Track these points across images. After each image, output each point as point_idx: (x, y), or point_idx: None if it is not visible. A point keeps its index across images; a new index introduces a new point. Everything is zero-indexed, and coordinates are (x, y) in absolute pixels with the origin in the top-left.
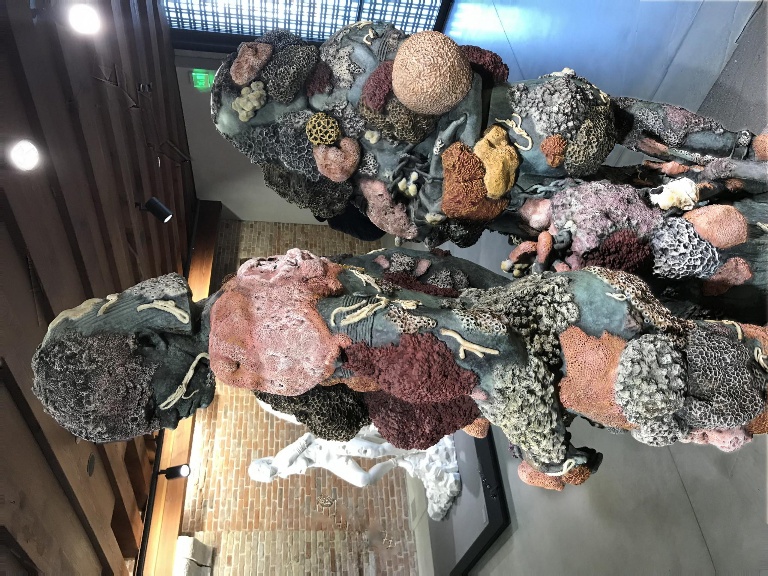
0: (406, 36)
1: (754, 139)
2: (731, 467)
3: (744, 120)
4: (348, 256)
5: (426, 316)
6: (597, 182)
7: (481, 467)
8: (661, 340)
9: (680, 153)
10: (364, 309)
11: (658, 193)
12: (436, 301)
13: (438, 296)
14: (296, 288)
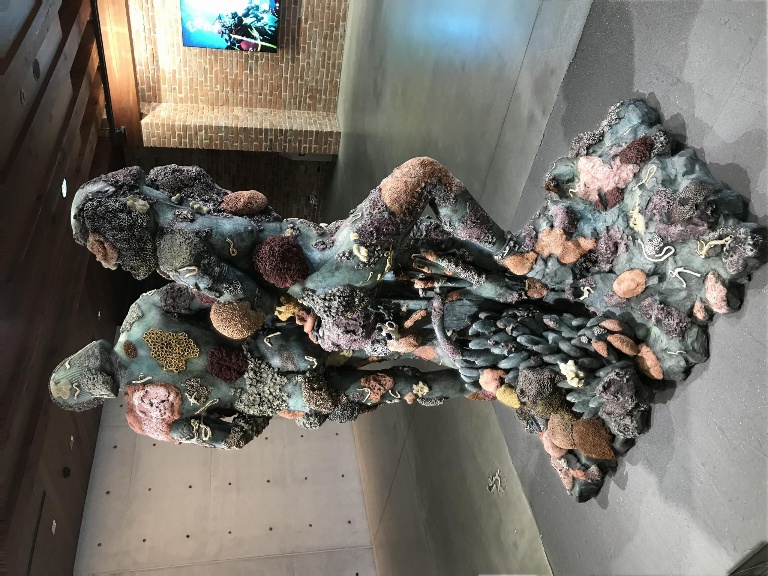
0: (221, 294)
1: (506, 258)
2: (531, 128)
3: (676, 37)
4: (195, 297)
5: (211, 444)
6: (342, 331)
7: (316, 186)
8: (315, 423)
9: (442, 264)
10: (187, 441)
11: (379, 332)
12: (228, 390)
13: (231, 383)
14: (160, 425)
